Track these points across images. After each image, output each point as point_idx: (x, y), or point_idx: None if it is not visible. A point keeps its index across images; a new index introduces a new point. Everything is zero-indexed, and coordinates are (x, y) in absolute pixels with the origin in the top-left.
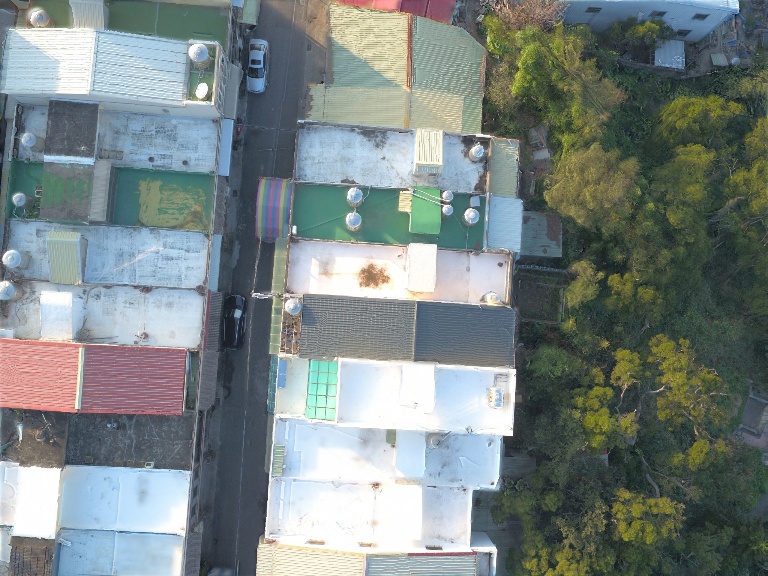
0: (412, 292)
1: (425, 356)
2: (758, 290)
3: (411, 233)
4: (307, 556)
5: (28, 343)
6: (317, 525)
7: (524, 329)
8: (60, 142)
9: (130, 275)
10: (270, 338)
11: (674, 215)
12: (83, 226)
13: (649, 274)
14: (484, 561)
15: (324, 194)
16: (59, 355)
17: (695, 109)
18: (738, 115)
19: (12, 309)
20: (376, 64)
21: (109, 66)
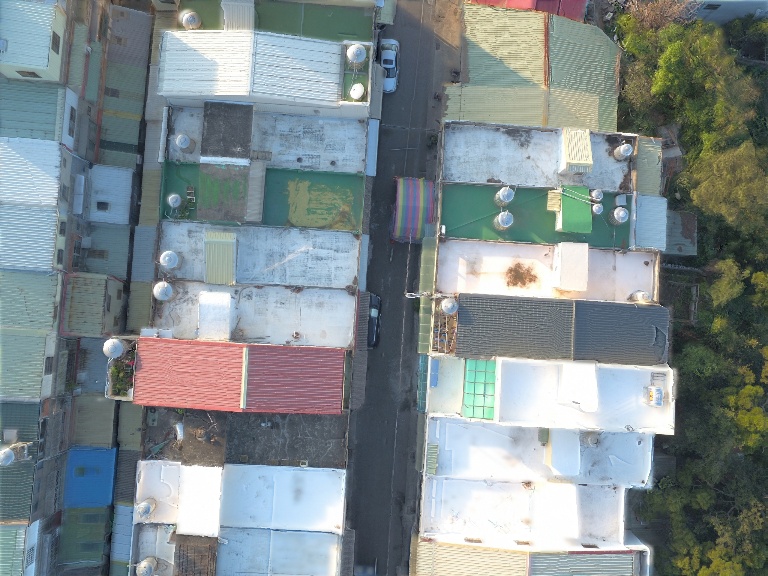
0: (560, 291)
1: (584, 355)
2: None
3: (558, 232)
4: (469, 554)
5: (191, 343)
6: (469, 523)
7: None
8: (216, 143)
9: (281, 275)
10: (419, 337)
11: None
12: (234, 227)
13: None
14: (635, 559)
15: (470, 193)
16: (223, 355)
17: None
18: None
19: (166, 309)
20: (512, 63)
21: (267, 67)
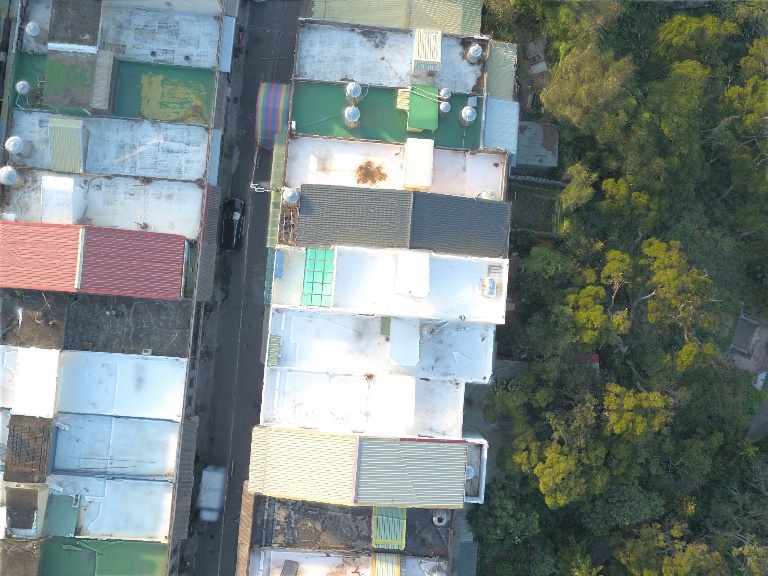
0: (409, 189)
1: (420, 245)
2: (751, 207)
3: (409, 132)
4: (301, 438)
5: (29, 224)
6: (311, 415)
7: (519, 237)
8: (64, 30)
9: (131, 167)
10: (268, 232)
11: (669, 127)
12: (85, 118)
13: (643, 181)
14: (475, 454)
15: (323, 92)
16: (60, 236)
17: (692, 26)
18: (734, 34)
19: (14, 197)
20: None
21: None
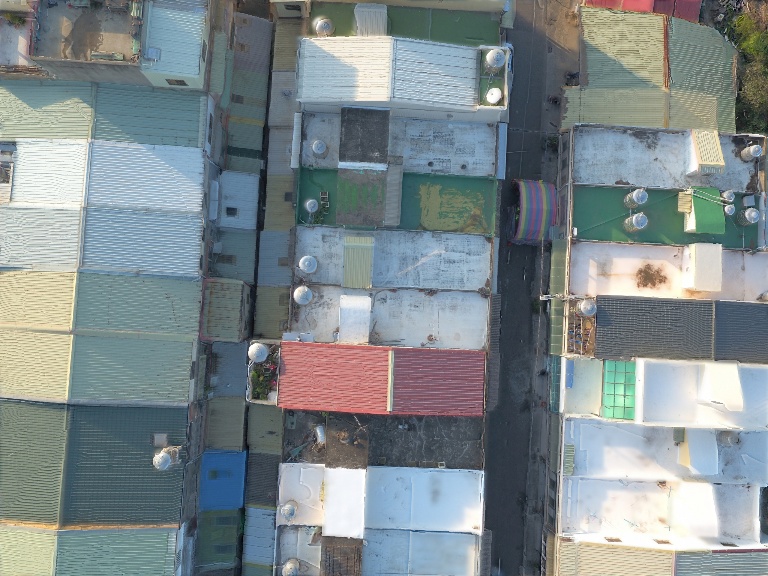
0: (691, 292)
1: (725, 355)
2: None
3: (687, 233)
4: (613, 553)
5: (335, 347)
6: (605, 523)
7: None
8: (354, 148)
9: (414, 278)
10: (550, 339)
11: None
12: (367, 231)
13: None
14: None
15: (599, 196)
16: (368, 358)
17: None
18: None
19: (302, 313)
20: (630, 65)
21: (406, 73)
